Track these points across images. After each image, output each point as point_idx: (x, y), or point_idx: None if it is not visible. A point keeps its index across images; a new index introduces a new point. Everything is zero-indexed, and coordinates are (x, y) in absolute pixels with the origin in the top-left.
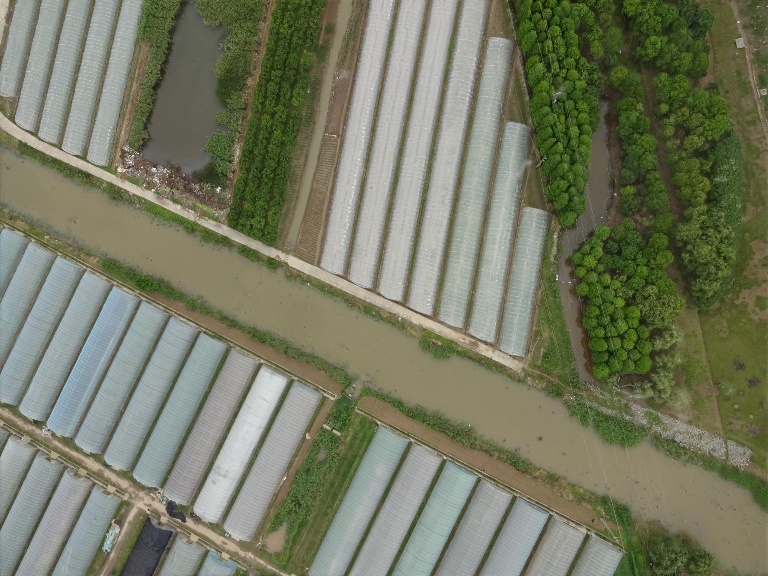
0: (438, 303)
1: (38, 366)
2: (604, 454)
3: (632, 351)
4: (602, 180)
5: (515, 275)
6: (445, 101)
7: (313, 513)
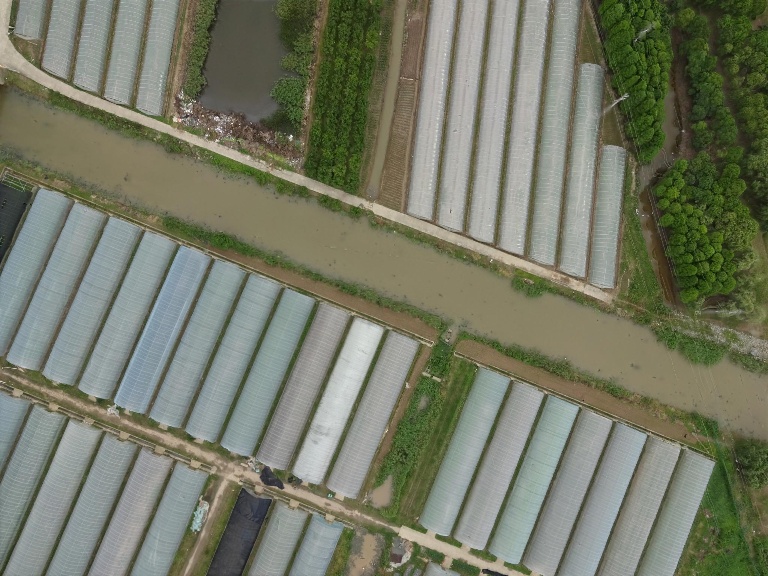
0: (528, 243)
1: (96, 340)
2: (690, 374)
3: (720, 273)
4: (670, 118)
5: (601, 211)
6: (521, 43)
7: (419, 462)
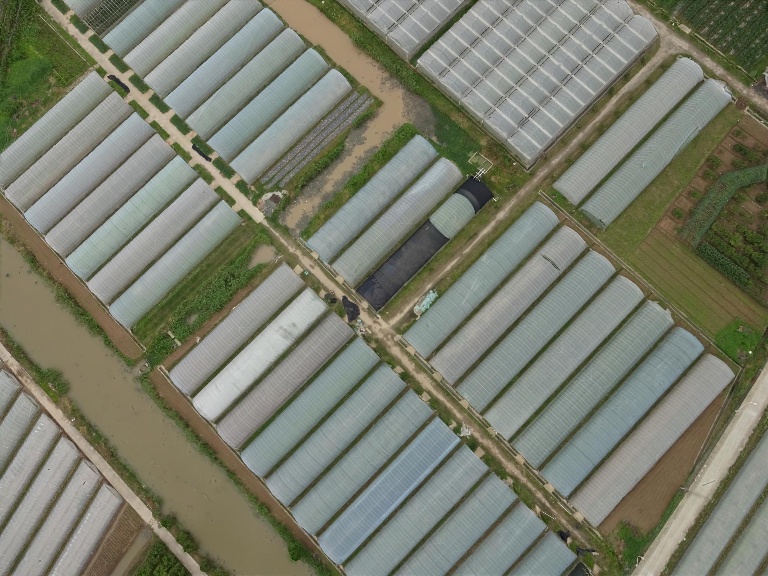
0: (34, 422)
1: (457, 507)
2: None
3: None
4: None
5: None
6: None
7: None
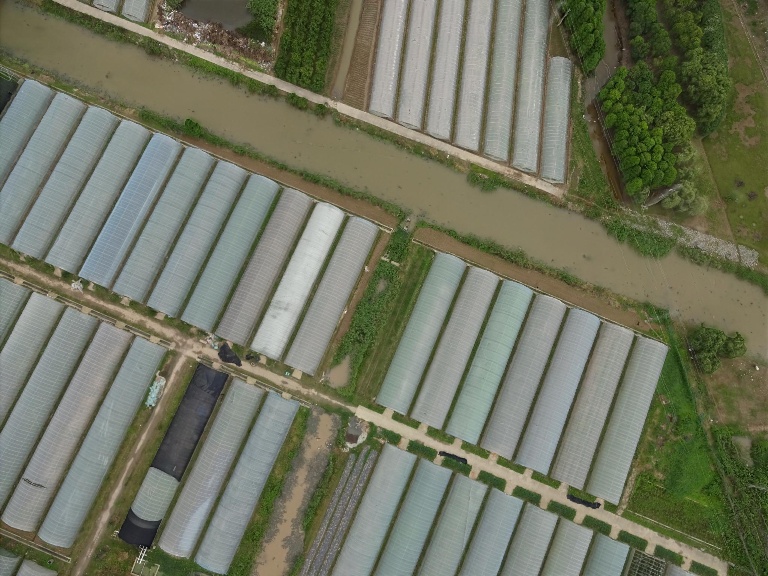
0: (482, 141)
1: (66, 218)
2: (640, 266)
3: (661, 162)
4: (611, 38)
5: (550, 113)
6: None
7: (377, 342)
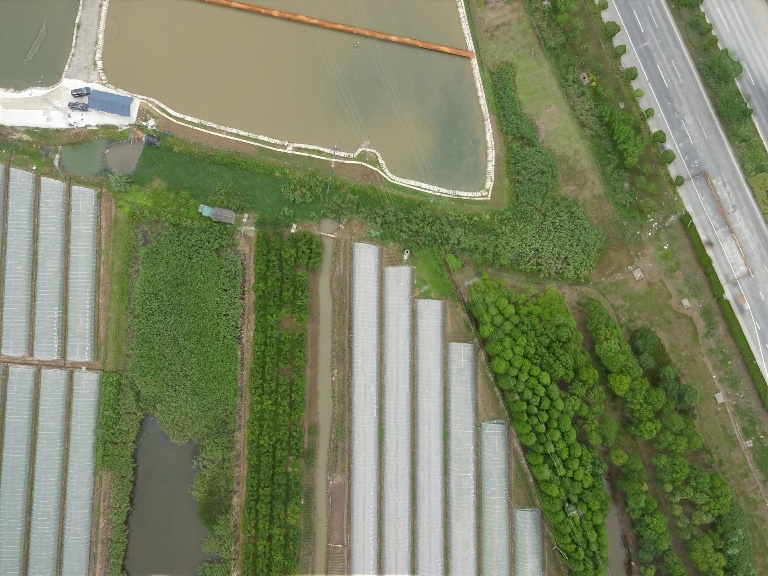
0: None
1: None
2: None
3: None
4: (617, 550)
5: None
6: (449, 495)
7: None
